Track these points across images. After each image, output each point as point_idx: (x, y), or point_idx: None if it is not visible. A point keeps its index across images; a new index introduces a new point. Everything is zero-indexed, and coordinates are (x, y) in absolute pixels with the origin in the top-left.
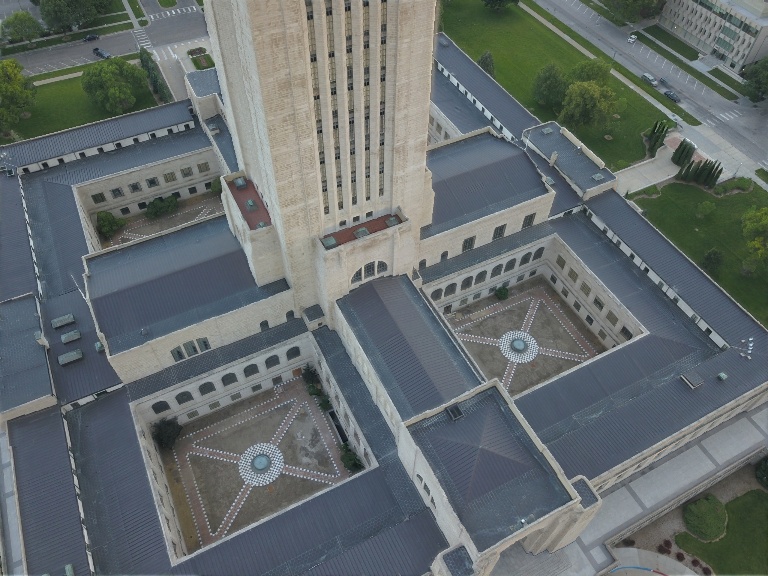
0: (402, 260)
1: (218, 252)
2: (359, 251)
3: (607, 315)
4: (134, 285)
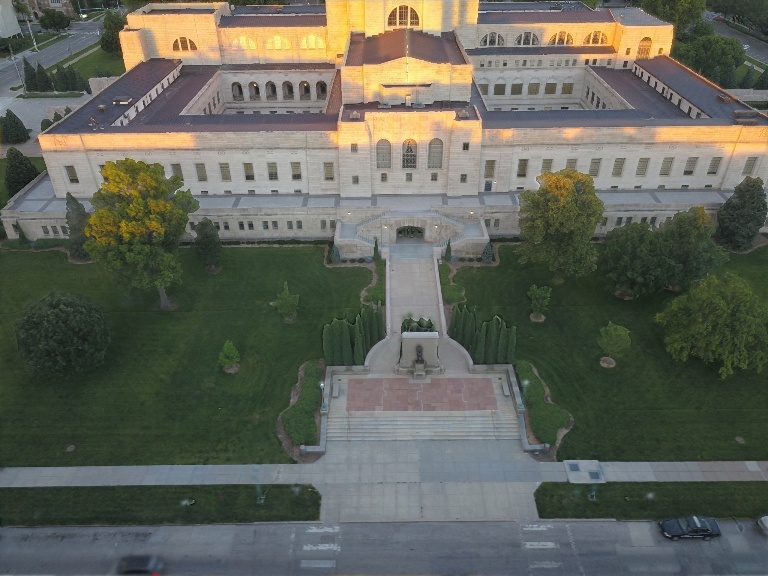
0: None
1: None
2: None
3: None
4: None
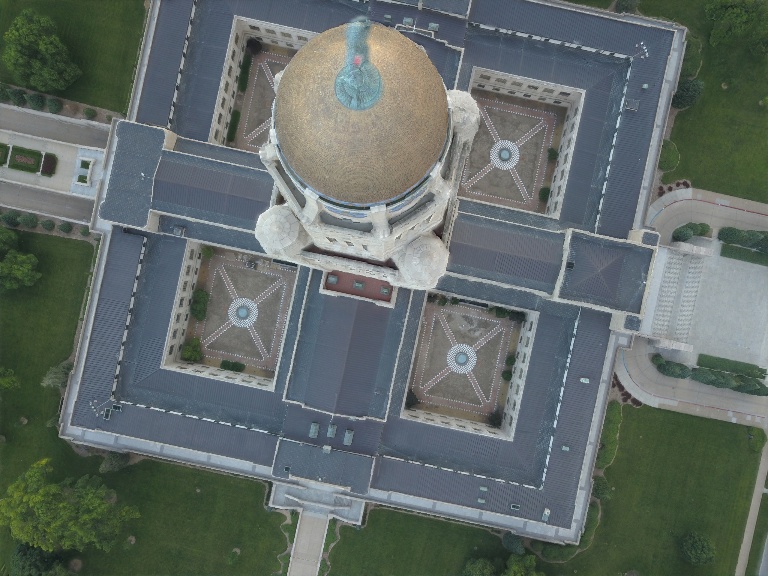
0: None
1: (349, 316)
2: None
3: (543, 90)
4: (341, 382)
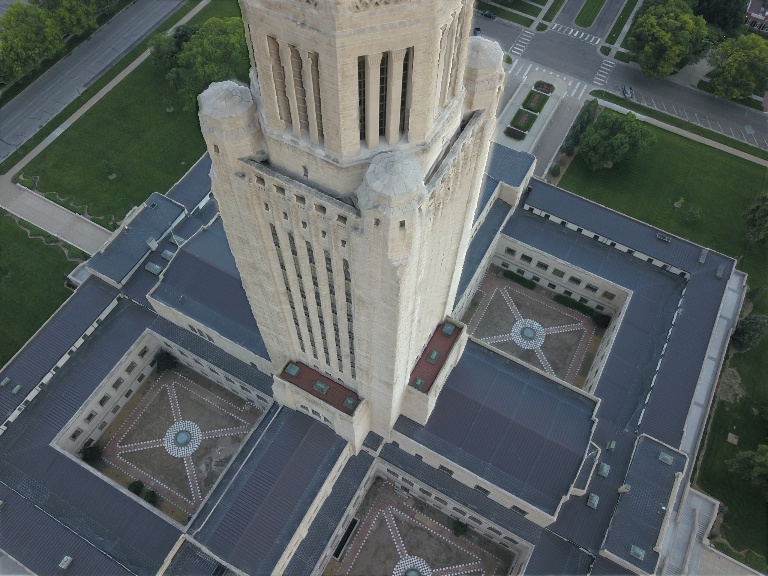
0: (343, 432)
1: None
2: (303, 398)
3: None
4: (209, 263)
